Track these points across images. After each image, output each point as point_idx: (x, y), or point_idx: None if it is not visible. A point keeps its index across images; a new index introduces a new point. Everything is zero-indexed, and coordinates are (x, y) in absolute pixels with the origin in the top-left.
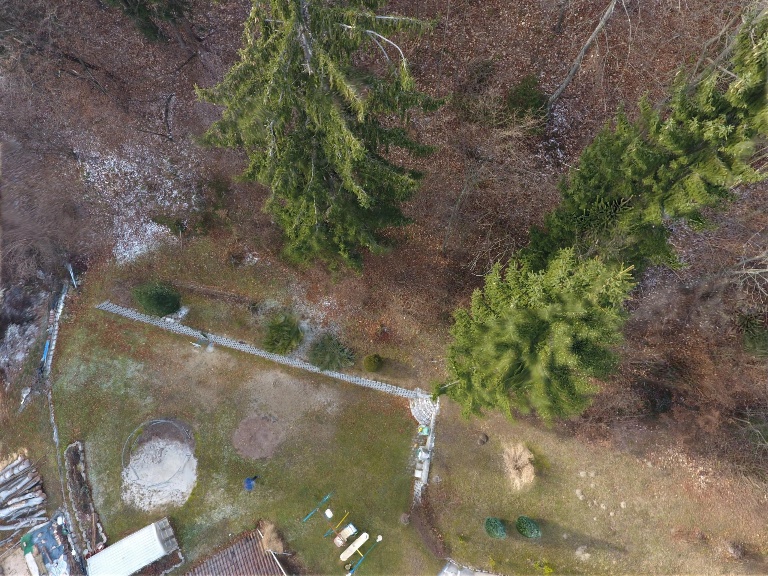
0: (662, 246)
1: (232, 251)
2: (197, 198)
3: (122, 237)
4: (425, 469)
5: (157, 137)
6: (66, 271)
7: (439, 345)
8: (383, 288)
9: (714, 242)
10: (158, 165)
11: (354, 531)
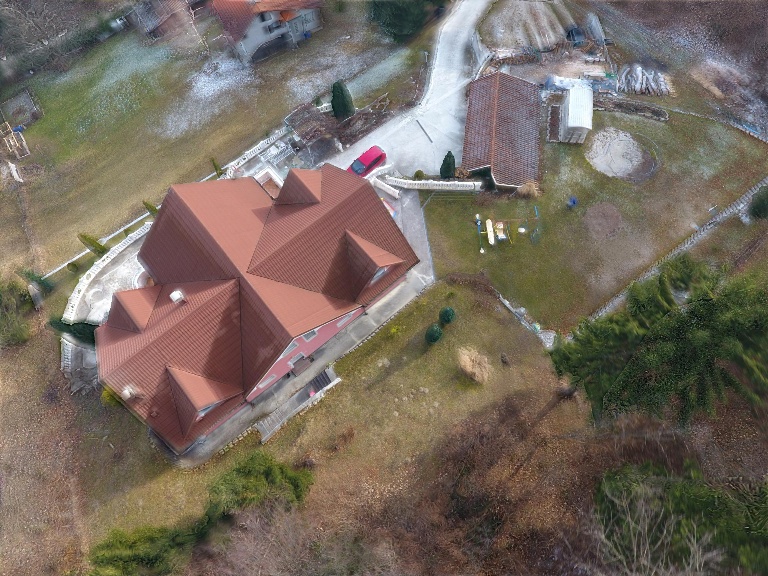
0: (714, 523)
1: None
2: None
3: None
4: None
5: None
6: None
7: None
8: (689, 371)
9: None
10: None
11: (500, 237)
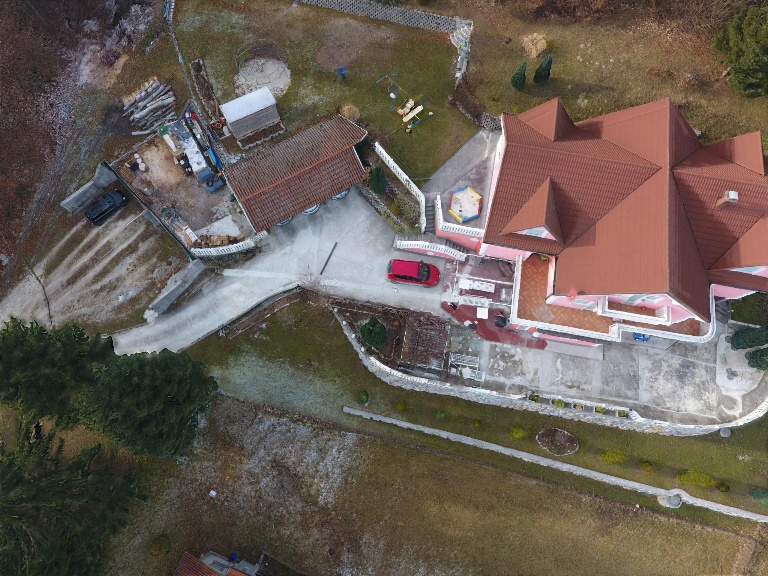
0: None
1: None
2: None
3: None
4: (464, 64)
5: None
6: None
7: None
8: None
9: None
10: None
11: (412, 104)
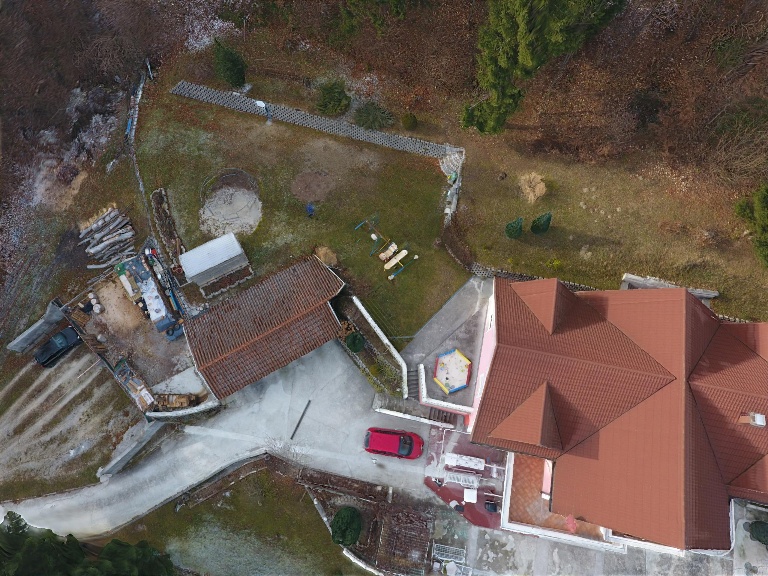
0: None
1: (288, 37)
2: None
3: (193, 32)
4: (454, 201)
5: None
6: (144, 64)
7: None
8: (417, 63)
9: None
10: None
11: (395, 248)
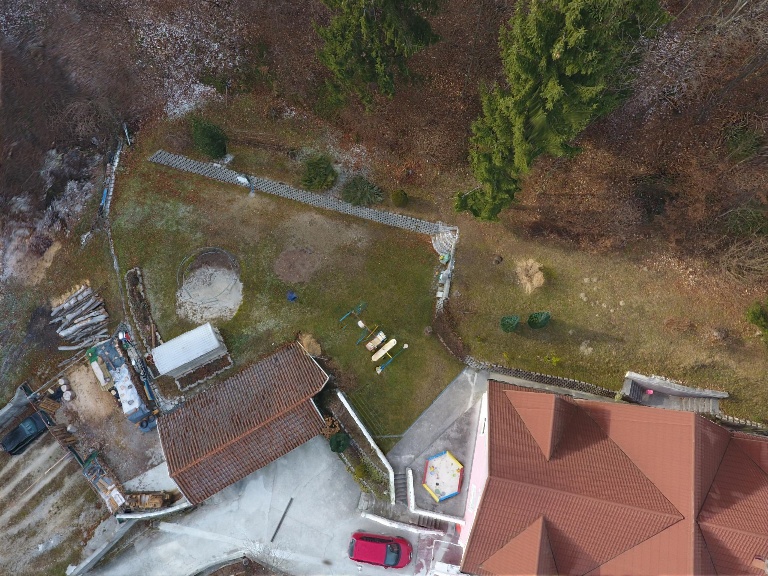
0: (655, 9)
1: (272, 105)
2: (241, 58)
3: (172, 97)
4: (446, 286)
5: (205, 4)
6: (121, 130)
7: (458, 183)
8: (408, 134)
9: (703, 71)
10: (206, 30)
11: (384, 337)
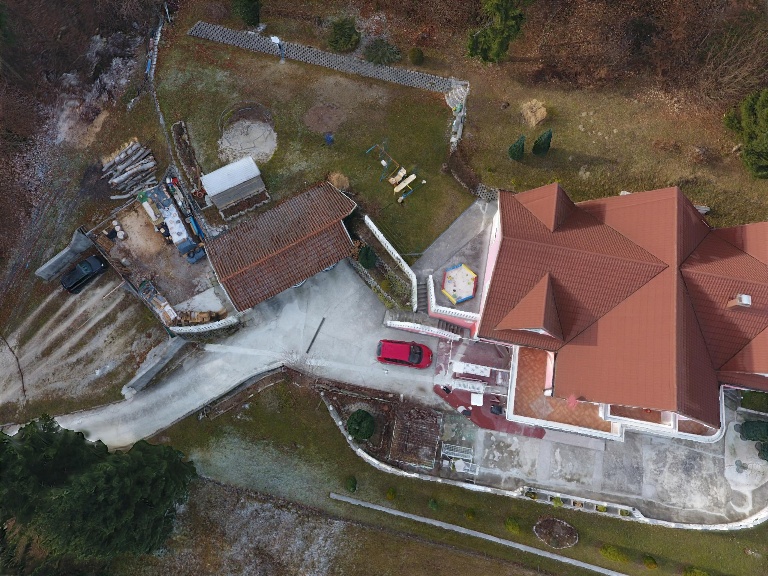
0: None
1: None
2: None
3: None
4: (459, 129)
5: None
6: (162, 8)
7: None
8: (423, 1)
9: None
10: None
11: (404, 173)
